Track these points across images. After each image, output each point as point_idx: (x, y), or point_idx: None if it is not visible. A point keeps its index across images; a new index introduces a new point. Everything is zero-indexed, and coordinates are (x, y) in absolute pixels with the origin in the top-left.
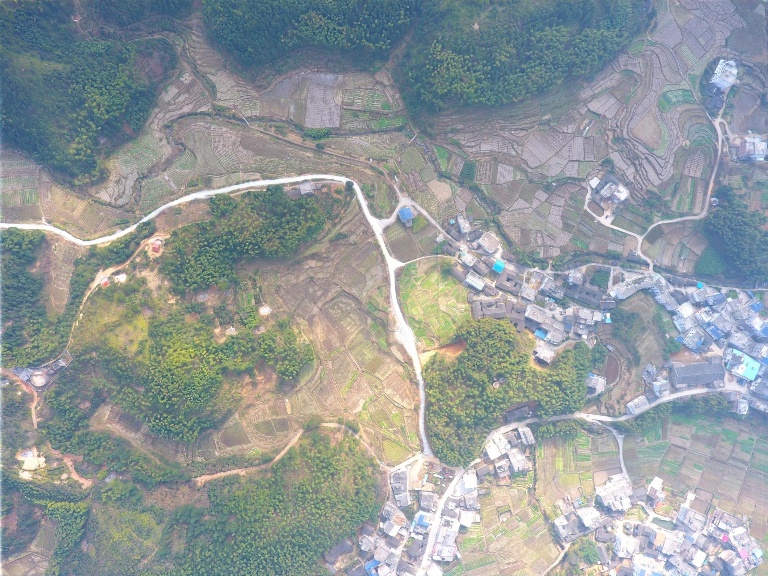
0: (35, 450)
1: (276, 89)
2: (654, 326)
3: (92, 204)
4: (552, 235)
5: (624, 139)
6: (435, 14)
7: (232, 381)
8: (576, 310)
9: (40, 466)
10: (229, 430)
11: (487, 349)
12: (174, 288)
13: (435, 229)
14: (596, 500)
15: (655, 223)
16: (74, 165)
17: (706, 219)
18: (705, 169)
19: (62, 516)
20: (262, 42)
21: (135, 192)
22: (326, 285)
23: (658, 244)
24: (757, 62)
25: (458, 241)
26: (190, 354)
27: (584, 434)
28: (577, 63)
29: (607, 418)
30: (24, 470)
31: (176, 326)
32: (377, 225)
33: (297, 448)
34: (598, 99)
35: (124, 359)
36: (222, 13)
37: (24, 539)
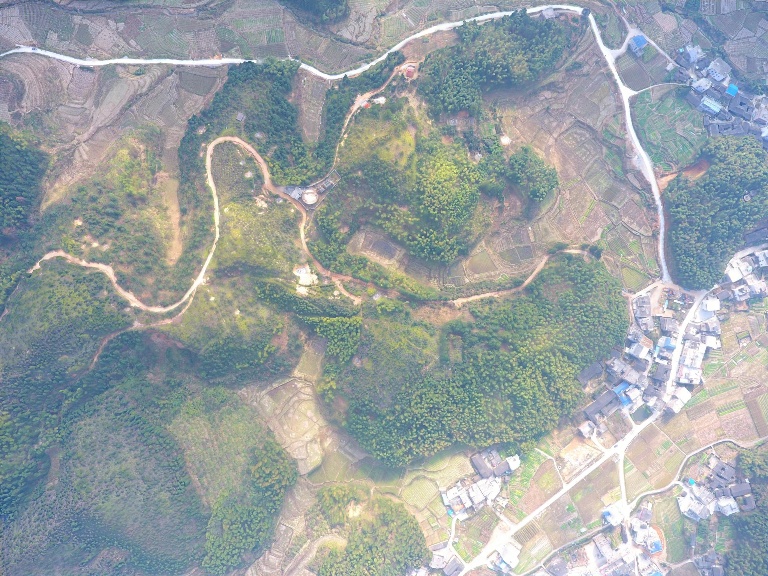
0: (308, 267)
1: None
2: None
3: (335, 42)
4: None
5: None
6: None
7: (485, 203)
8: None
9: (314, 282)
10: (476, 258)
11: (739, 160)
12: (432, 109)
13: (664, 59)
14: None
15: None
16: (322, 0)
17: None
18: None
19: (336, 331)
20: None
21: (374, 30)
22: (561, 116)
23: None
24: None
25: (687, 70)
26: (453, 171)
27: None
28: None
29: None
30: (300, 285)
31: (437, 144)
32: (610, 55)
33: None
34: None
35: (395, 173)
36: None
37: (291, 362)
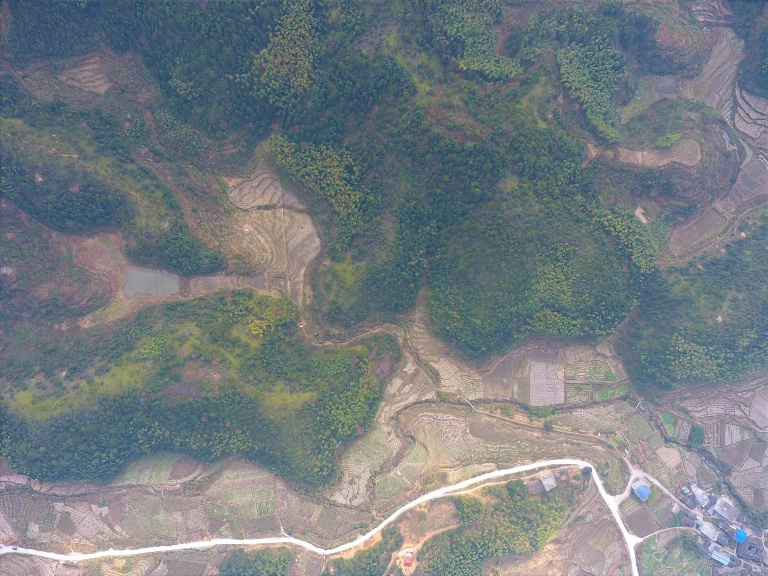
0: None
1: (498, 369)
2: None
3: (328, 508)
4: None
5: None
6: (670, 301)
7: None
8: None
9: None
10: None
11: None
12: None
13: (669, 499)
14: None
15: None
16: (313, 477)
17: None
18: None
19: None
20: (496, 341)
21: (369, 490)
22: (565, 566)
23: None
24: None
25: (693, 509)
26: None
27: None
28: None
29: None
30: None
31: None
32: (613, 503)
33: None
34: None
35: None
36: (457, 318)
37: None
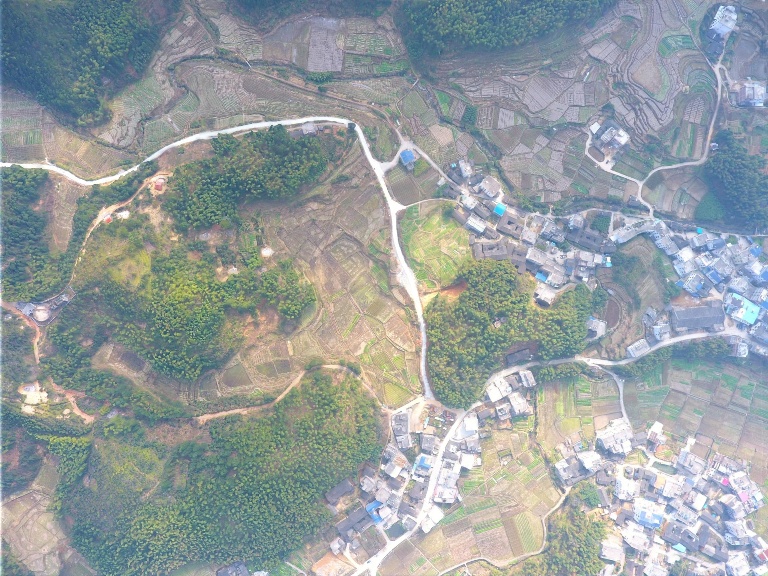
0: (37, 385)
1: (279, 33)
2: (654, 270)
3: (95, 145)
4: (553, 180)
5: (624, 84)
6: None
7: (234, 320)
8: (577, 253)
9: (42, 401)
10: (231, 371)
11: (488, 288)
12: (177, 225)
13: (437, 173)
14: (597, 444)
15: (655, 169)
16: (77, 105)
17: (706, 163)
18: (705, 115)
19: (64, 451)
20: None
21: (138, 134)
22: (328, 228)
23: (658, 190)
24: (756, 9)
25: (459, 185)
26: (192, 290)
27: (585, 379)
28: (578, 5)
29: (608, 362)
30: (26, 404)
31: (179, 262)
32: (379, 168)
33: (299, 388)
34: (599, 45)
35: (127, 293)
36: None
37: (26, 476)
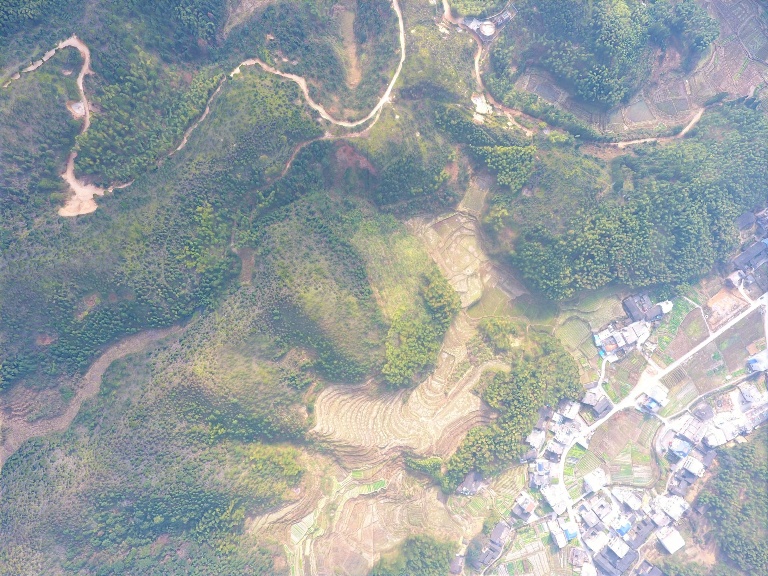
0: (483, 97)
1: None
2: None
3: None
4: None
5: None
6: None
7: (650, 49)
8: None
9: (489, 112)
10: (634, 107)
11: None
12: None
13: None
14: None
15: None
16: None
17: None
18: None
19: (509, 160)
20: None
21: None
22: None
23: None
24: None
25: None
26: None
27: None
28: None
29: None
30: (477, 113)
31: None
32: None
33: None
34: None
35: (573, 6)
36: None
37: (459, 194)
